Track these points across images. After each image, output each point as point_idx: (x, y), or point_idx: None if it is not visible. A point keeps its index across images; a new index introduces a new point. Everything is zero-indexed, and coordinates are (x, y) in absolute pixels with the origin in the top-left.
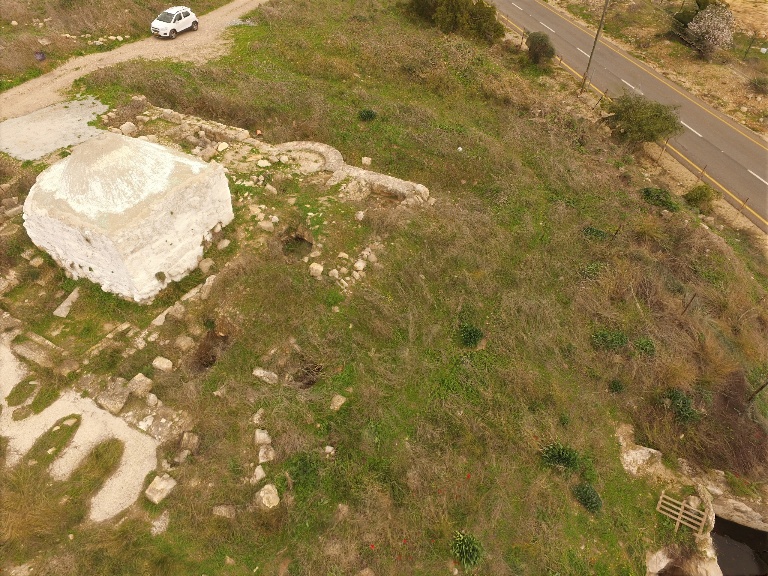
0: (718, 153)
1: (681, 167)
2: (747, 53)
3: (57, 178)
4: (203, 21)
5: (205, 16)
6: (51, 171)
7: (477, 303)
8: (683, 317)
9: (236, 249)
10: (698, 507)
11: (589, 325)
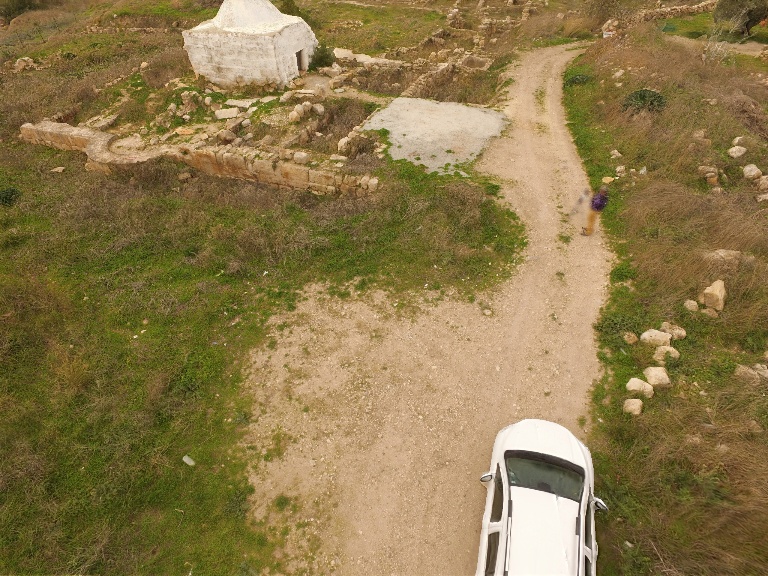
0: None
1: None
2: None
3: (286, 16)
4: None
5: None
6: (297, 21)
7: None
8: None
9: None
10: (29, 66)
11: None
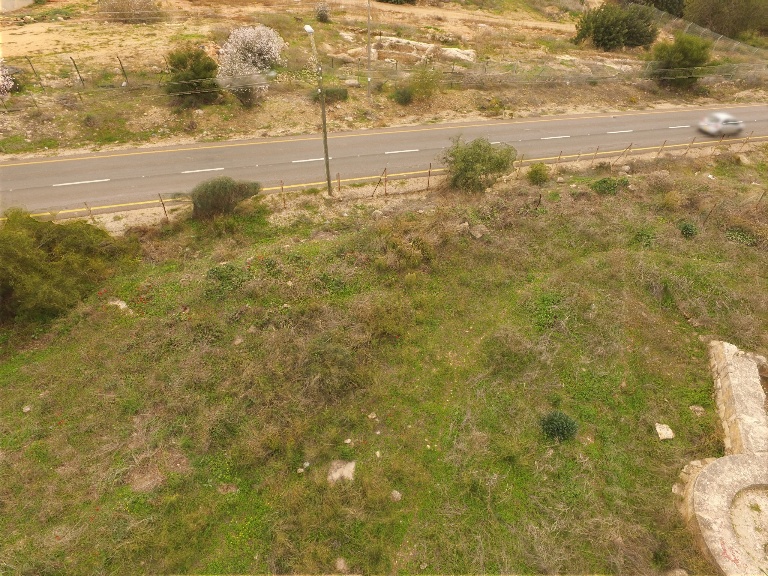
0: None
1: None
2: None
3: None
4: None
5: None
6: None
7: None
8: (759, 208)
9: None
10: None
11: None
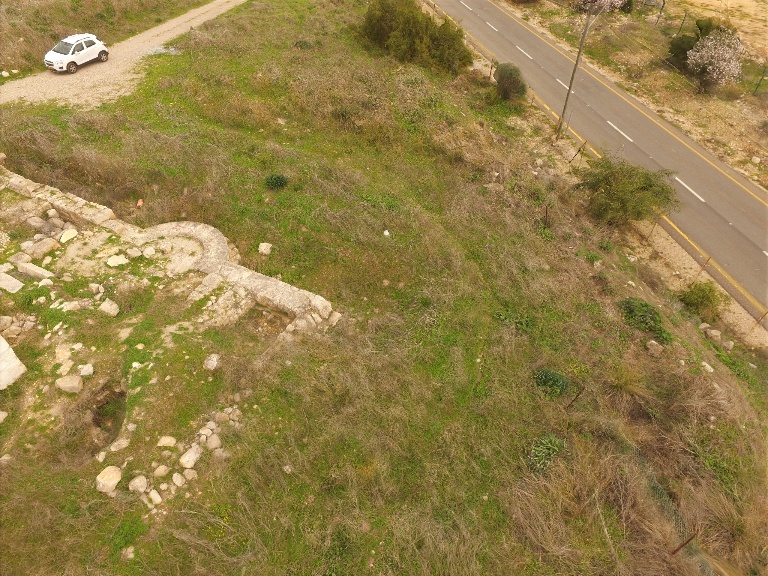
0: (725, 226)
1: (677, 248)
2: (758, 87)
3: None
4: (118, 49)
5: (123, 42)
6: None
7: (361, 523)
8: (675, 560)
9: (13, 428)
10: None
11: (529, 568)
